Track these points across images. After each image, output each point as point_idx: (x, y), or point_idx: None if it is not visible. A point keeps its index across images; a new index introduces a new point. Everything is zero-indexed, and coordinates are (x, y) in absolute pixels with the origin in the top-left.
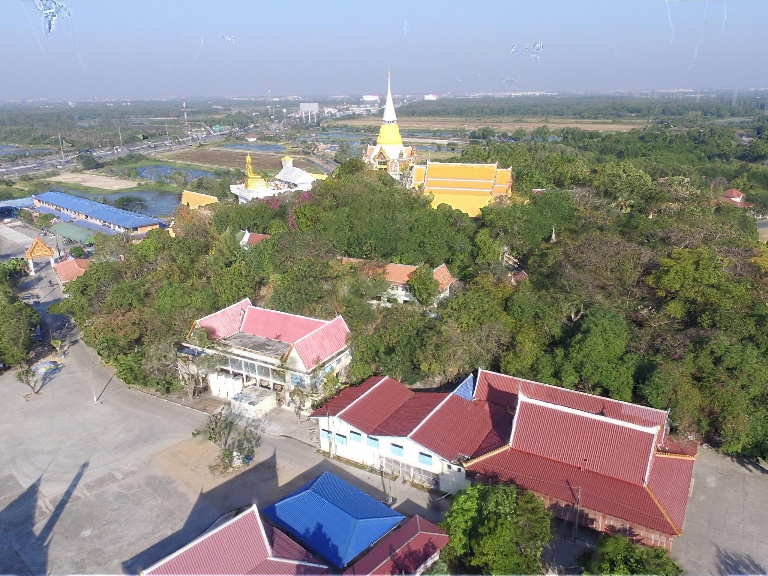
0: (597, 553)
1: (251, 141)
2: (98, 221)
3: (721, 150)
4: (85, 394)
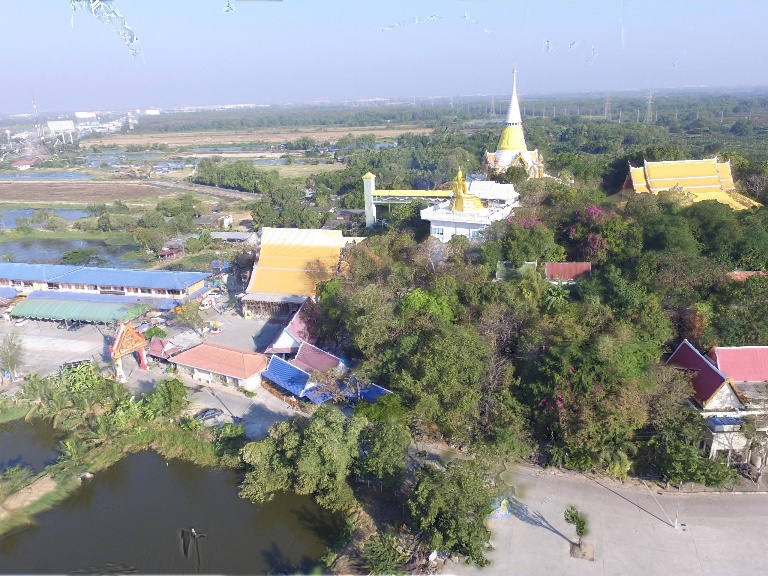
0: None
1: (23, 169)
2: (86, 289)
3: (549, 145)
4: (634, 521)
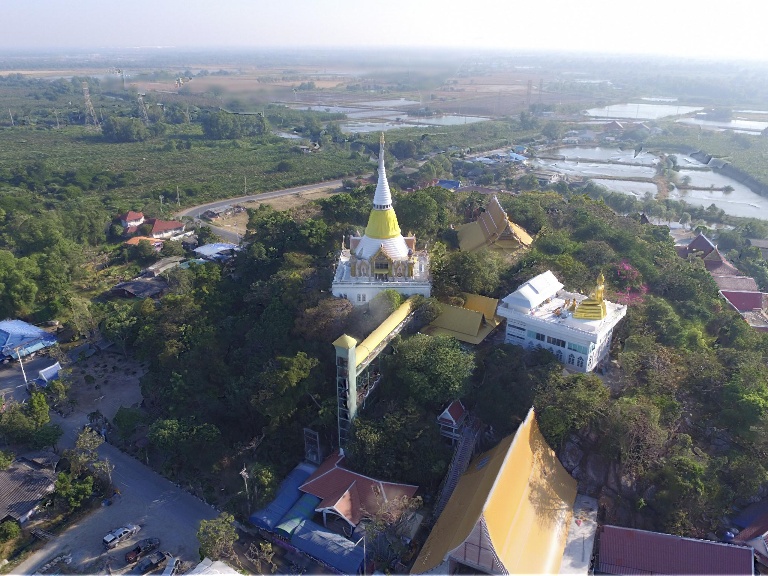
0: (750, 255)
1: None
2: None
3: None
4: None
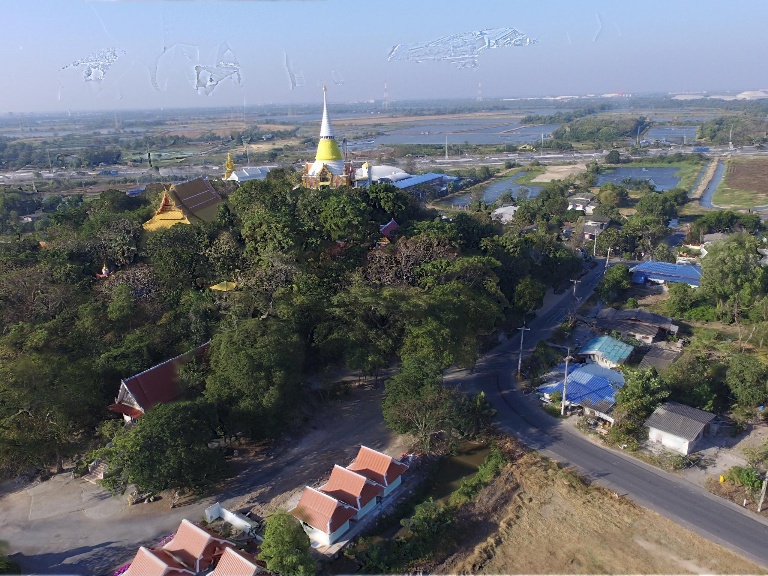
0: None
1: None
2: None
3: None
4: None
